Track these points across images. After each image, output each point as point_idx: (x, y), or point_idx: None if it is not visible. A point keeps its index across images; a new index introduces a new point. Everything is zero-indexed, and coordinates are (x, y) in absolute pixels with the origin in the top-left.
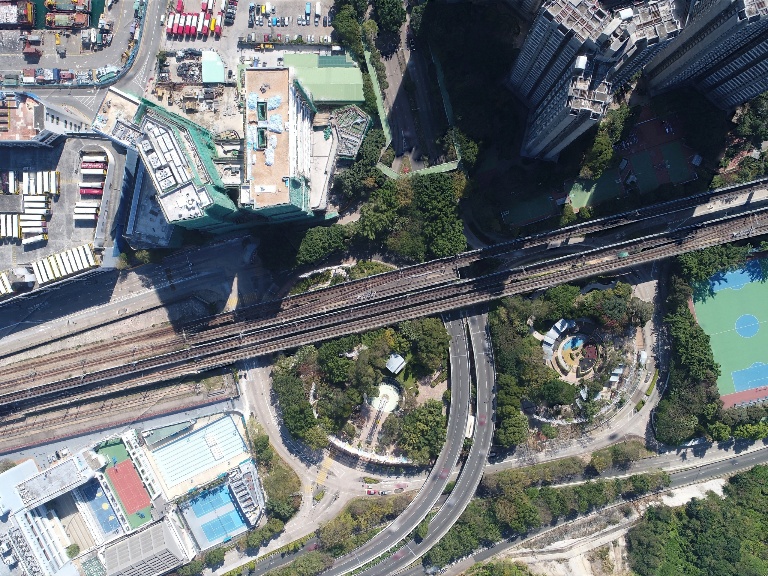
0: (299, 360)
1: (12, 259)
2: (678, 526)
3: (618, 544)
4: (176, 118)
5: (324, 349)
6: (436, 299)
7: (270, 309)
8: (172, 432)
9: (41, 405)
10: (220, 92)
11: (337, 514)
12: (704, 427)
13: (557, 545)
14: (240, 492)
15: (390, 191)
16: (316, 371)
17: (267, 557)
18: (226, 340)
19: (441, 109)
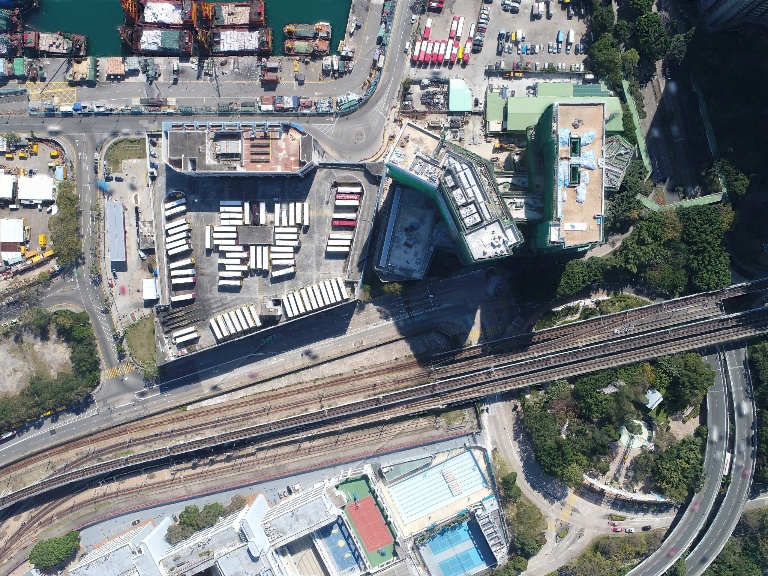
0: (553, 395)
1: (258, 291)
2: None
3: None
4: (469, 152)
5: (581, 384)
6: (698, 334)
7: (521, 343)
8: (412, 468)
9: (275, 439)
10: (467, 121)
11: (581, 552)
12: None
13: None
14: (487, 530)
15: (655, 224)
16: (569, 406)
17: None
18: (475, 374)
19: (704, 140)
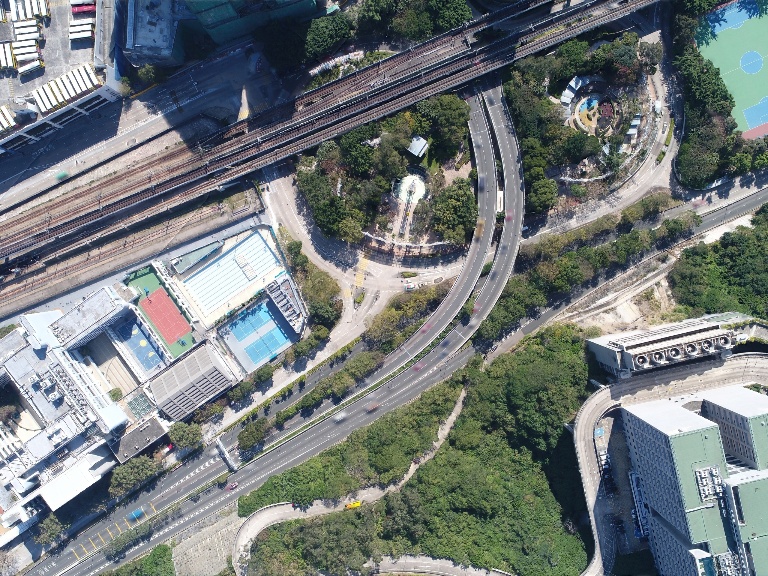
0: (321, 156)
1: (10, 93)
2: (715, 258)
3: (661, 285)
4: None
5: (345, 140)
6: (450, 74)
7: (284, 111)
8: (201, 255)
9: (61, 250)
10: None
11: (380, 314)
12: None
13: (602, 301)
14: (280, 302)
15: None
16: (340, 166)
17: (316, 370)
18: (244, 149)
19: None
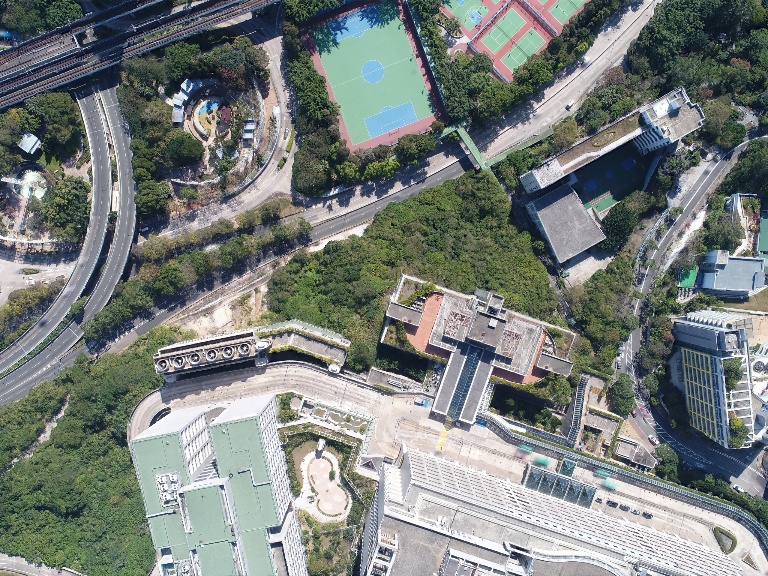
0: None
1: None
2: (315, 266)
3: (259, 290)
4: None
5: None
6: (58, 72)
7: None
8: None
9: None
10: None
11: None
12: (334, 170)
13: (209, 304)
14: None
15: None
16: None
17: None
18: None
19: None
